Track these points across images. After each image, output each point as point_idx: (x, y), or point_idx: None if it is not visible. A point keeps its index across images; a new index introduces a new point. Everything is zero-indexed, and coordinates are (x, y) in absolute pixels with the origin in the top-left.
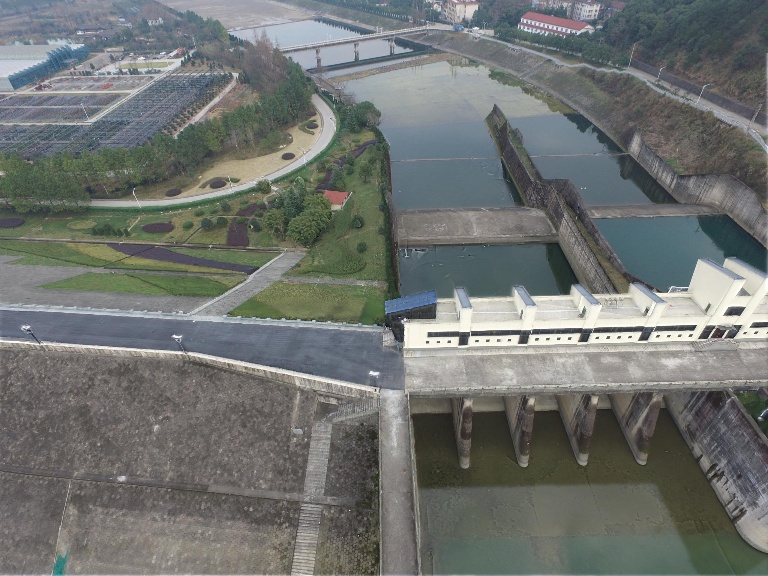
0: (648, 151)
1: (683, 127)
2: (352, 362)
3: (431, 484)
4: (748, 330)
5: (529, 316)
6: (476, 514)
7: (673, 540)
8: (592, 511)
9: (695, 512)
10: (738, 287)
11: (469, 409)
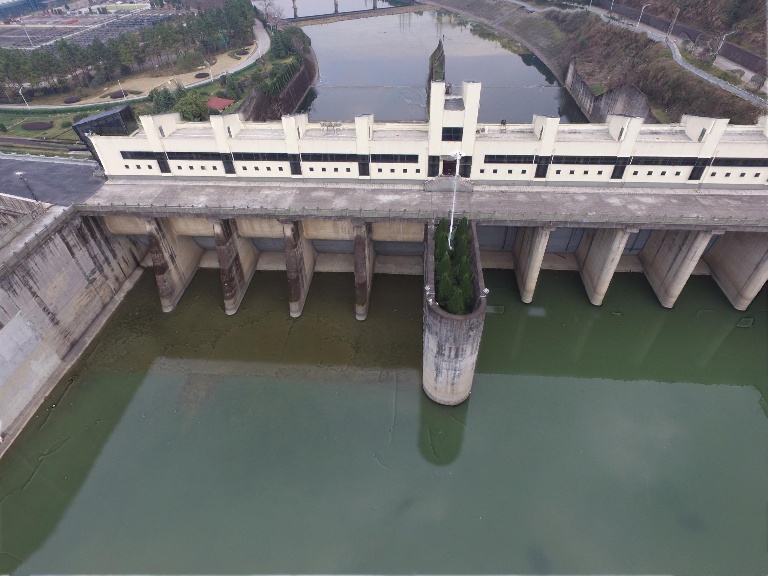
0: (577, 79)
1: (618, 53)
2: (48, 186)
3: (121, 323)
4: (484, 167)
5: (219, 131)
6: (147, 350)
7: (345, 386)
8: (273, 356)
9: (388, 364)
10: (440, 94)
11: (151, 235)
